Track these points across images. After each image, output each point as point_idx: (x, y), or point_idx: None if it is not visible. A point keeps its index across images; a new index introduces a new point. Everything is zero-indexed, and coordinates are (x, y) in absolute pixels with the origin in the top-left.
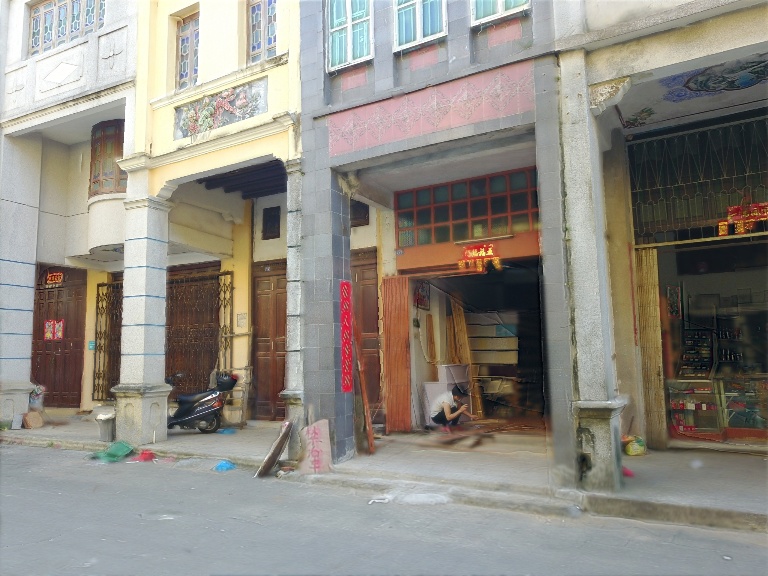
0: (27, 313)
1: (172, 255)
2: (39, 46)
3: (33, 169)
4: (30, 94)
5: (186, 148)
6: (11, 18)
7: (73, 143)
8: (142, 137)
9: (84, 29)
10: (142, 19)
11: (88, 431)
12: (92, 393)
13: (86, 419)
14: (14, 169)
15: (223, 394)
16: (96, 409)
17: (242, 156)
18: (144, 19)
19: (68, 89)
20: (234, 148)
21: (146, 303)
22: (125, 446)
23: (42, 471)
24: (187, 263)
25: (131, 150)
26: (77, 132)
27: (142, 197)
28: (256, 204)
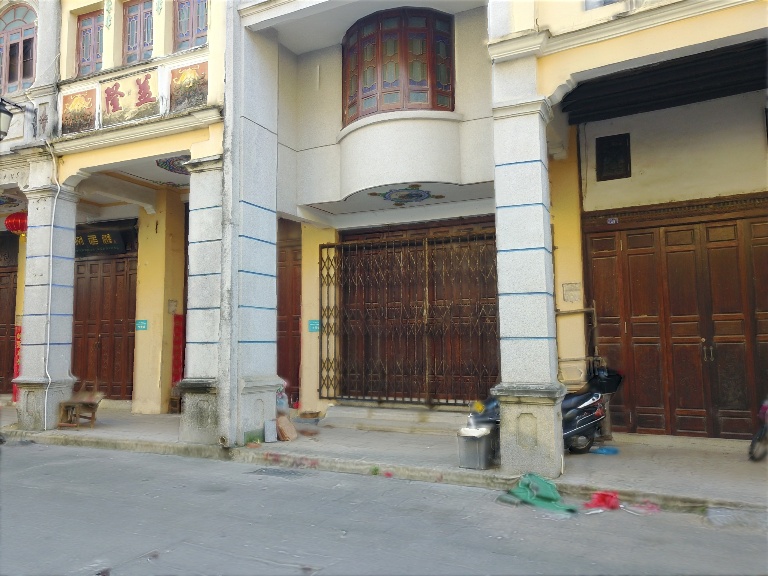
0: (271, 279)
1: (449, 204)
2: None
3: (271, 80)
4: None
5: (635, 14)
6: None
7: (304, 51)
8: (529, 7)
9: None
10: None
11: (379, 446)
12: (318, 389)
13: (327, 425)
14: (254, 77)
15: (606, 397)
16: (332, 411)
17: (763, 19)
18: None
19: None
20: (740, 8)
21: (545, 260)
22: (544, 481)
23: (524, 538)
24: (469, 215)
25: (507, 28)
26: (328, 30)
27: (532, 98)
28: (585, 132)
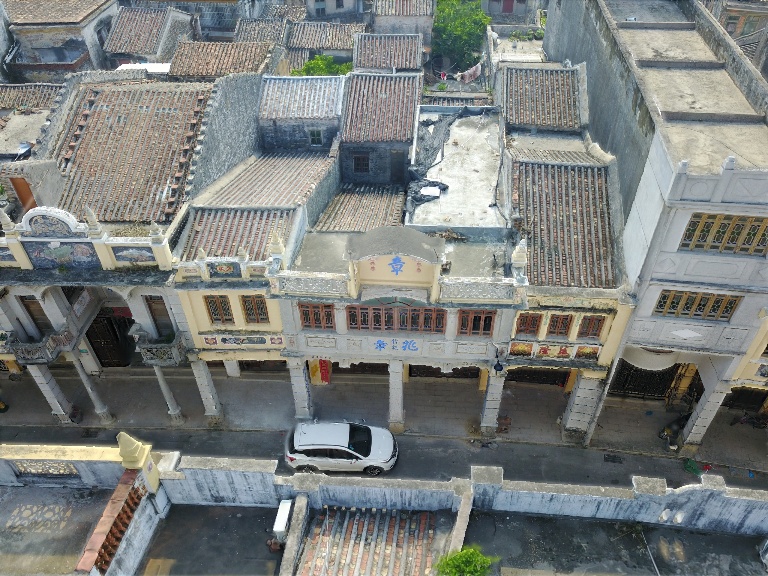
0: None
1: None
2: (664, 310)
3: None
4: (656, 336)
5: None
6: (647, 293)
7: None
8: None
9: (708, 314)
10: (762, 330)
11: (625, 429)
12: None
13: None
14: None
15: None
16: None
17: None
18: (764, 331)
19: (691, 342)
20: None
21: None
22: None
23: None
24: None
25: None
26: None
27: (728, 392)
28: None
